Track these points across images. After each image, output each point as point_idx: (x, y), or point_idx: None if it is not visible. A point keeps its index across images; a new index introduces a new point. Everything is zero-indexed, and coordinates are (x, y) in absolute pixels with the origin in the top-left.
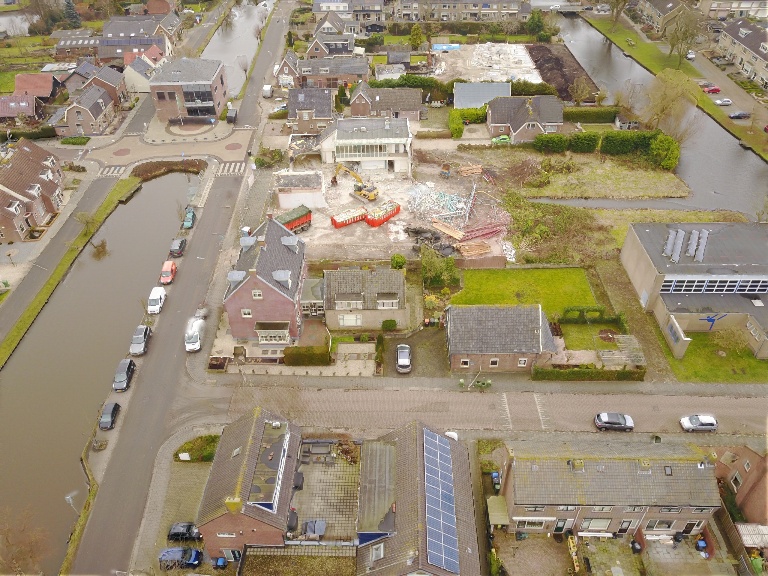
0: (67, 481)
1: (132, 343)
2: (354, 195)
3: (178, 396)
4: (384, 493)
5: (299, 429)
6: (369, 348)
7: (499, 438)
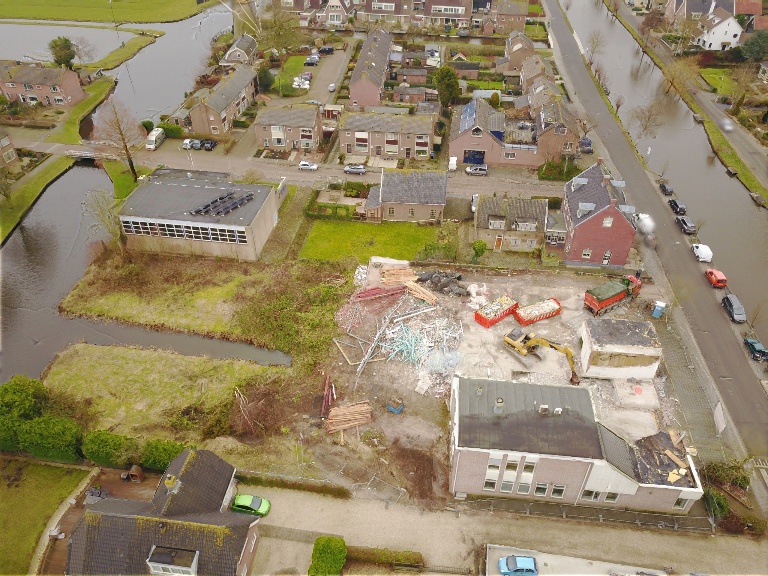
0: None
1: None
2: None
3: (630, 198)
4: None
5: None
6: None
7: None
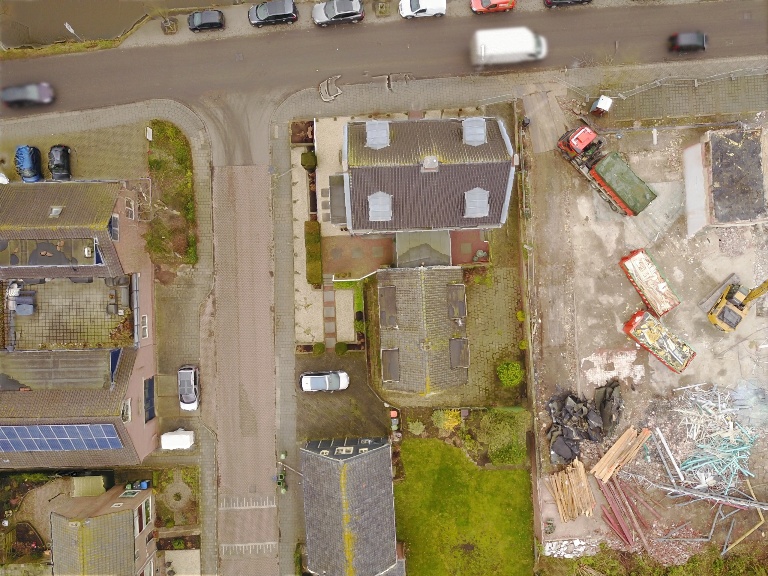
0: (129, 7)
1: (327, 3)
2: (725, 284)
3: (248, 96)
4: (42, 378)
5: (120, 274)
6: (346, 333)
7: (204, 493)
